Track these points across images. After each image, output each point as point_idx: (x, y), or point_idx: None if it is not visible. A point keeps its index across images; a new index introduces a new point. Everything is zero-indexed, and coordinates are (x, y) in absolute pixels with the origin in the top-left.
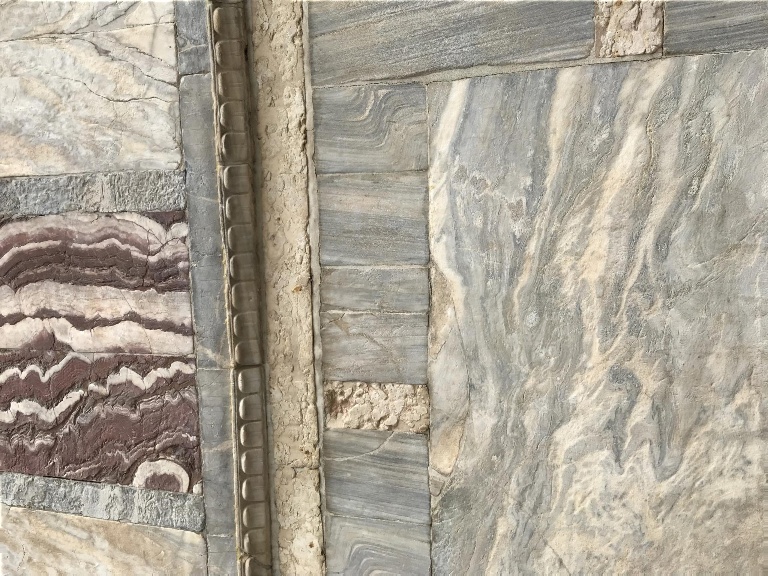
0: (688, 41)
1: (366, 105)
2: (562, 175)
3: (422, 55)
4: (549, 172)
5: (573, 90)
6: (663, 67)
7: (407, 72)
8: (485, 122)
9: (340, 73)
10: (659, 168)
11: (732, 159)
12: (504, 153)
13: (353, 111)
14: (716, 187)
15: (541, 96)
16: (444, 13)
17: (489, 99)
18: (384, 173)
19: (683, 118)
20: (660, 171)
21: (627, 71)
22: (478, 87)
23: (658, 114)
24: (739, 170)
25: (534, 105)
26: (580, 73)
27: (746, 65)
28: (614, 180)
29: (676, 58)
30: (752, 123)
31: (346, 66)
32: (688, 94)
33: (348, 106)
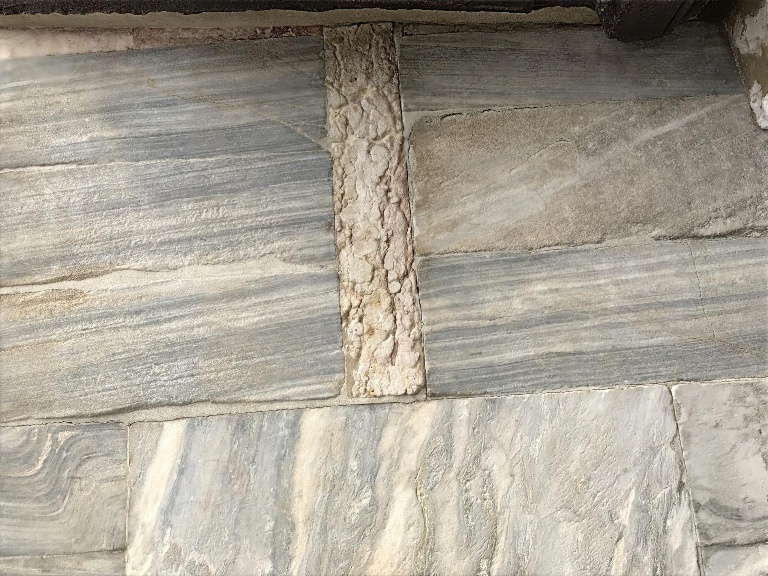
0: (454, 381)
1: (39, 453)
2: (313, 557)
3: (123, 386)
4: (295, 553)
5: (322, 438)
6: (429, 412)
7: (101, 408)
8: (207, 480)
9: (4, 407)
10: (437, 546)
11: (524, 533)
12: (234, 525)
13: (19, 462)
14: (510, 572)
15: (281, 446)
16: (154, 333)
17: (213, 448)
18: (59, 555)
19: (459, 478)
20: (439, 551)
21: (387, 416)
22: (198, 431)
23: (429, 472)
24: (534, 548)
25: (272, 458)
26: (330, 416)
27: (523, 412)
28: (381, 564)
29: (443, 401)
30: (540, 485)
31: (13, 398)
32: (462, 447)
33: (11, 455)
